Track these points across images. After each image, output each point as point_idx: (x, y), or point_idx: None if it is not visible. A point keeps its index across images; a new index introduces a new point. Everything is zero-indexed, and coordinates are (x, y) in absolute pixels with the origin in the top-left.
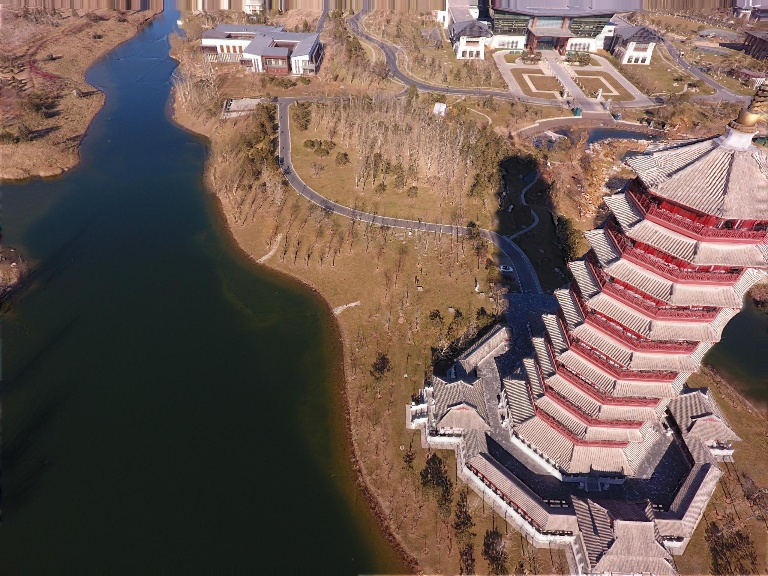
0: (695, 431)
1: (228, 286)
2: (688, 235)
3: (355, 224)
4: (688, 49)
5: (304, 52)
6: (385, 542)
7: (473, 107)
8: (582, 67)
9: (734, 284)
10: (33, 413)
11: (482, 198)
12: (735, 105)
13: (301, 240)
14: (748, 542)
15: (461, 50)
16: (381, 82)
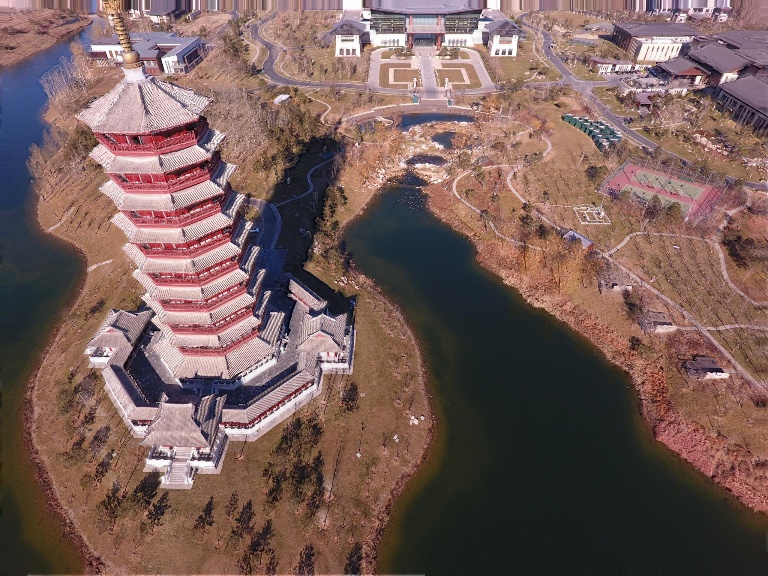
0: (306, 346)
1: (10, 251)
2: None
3: None
4: (558, 41)
5: (173, 53)
6: (21, 439)
7: (320, 98)
8: (451, 60)
9: (187, 195)
10: None
11: (267, 173)
12: (563, 88)
13: (88, 212)
14: (318, 432)
15: (338, 48)
16: (245, 79)
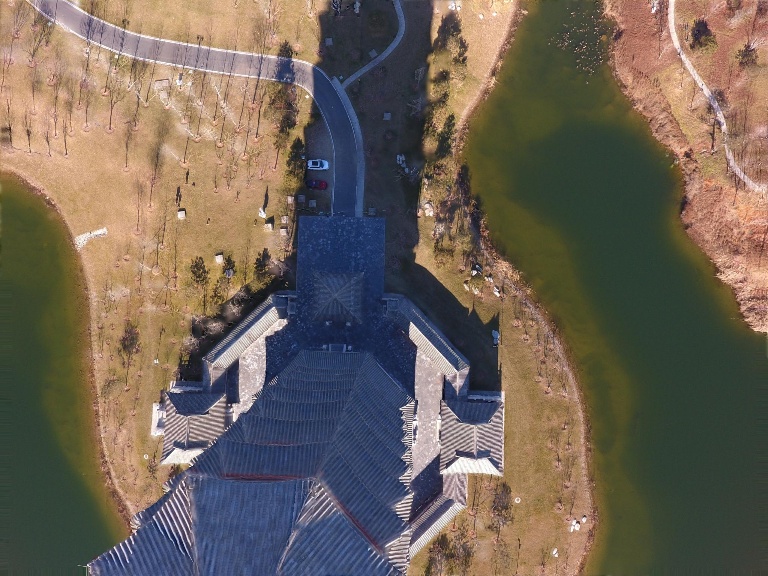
0: (454, 467)
1: None
2: None
3: (91, 58)
4: None
5: None
6: None
7: None
8: None
9: None
10: None
11: None
12: None
13: (10, 98)
14: (470, 552)
15: None
16: None
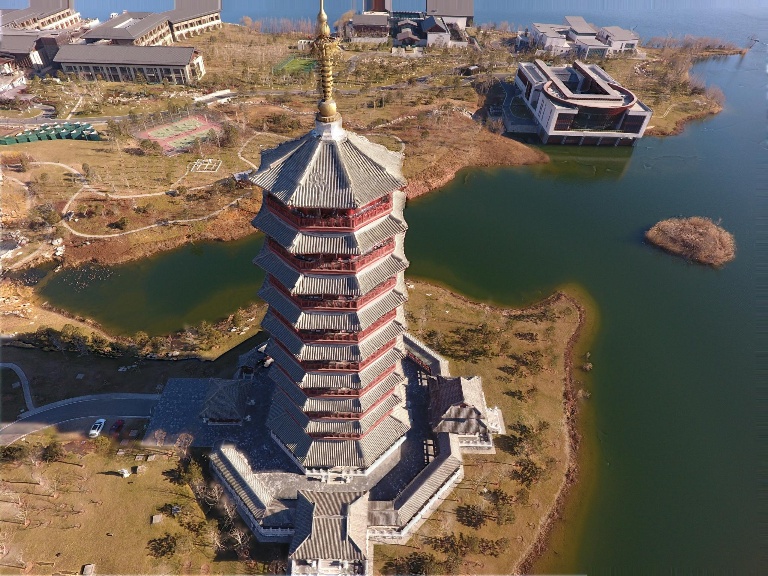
0: None
1: None
2: (381, 216)
3: None
4: None
5: None
6: None
7: None
8: None
9: None
10: None
11: None
12: None
13: None
14: (434, 333)
15: None
16: None
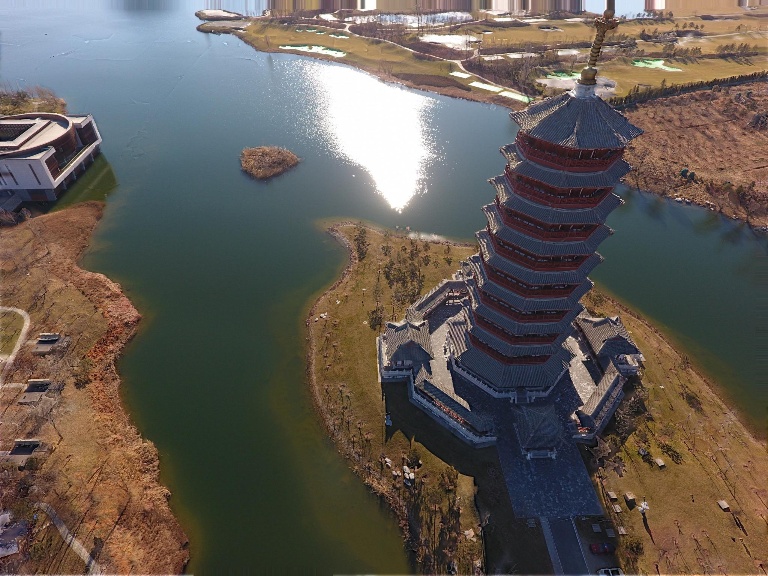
0: None
1: None
2: None
3: None
4: None
5: None
6: None
7: None
8: None
9: None
10: None
11: None
12: None
13: None
14: None
15: None
16: None
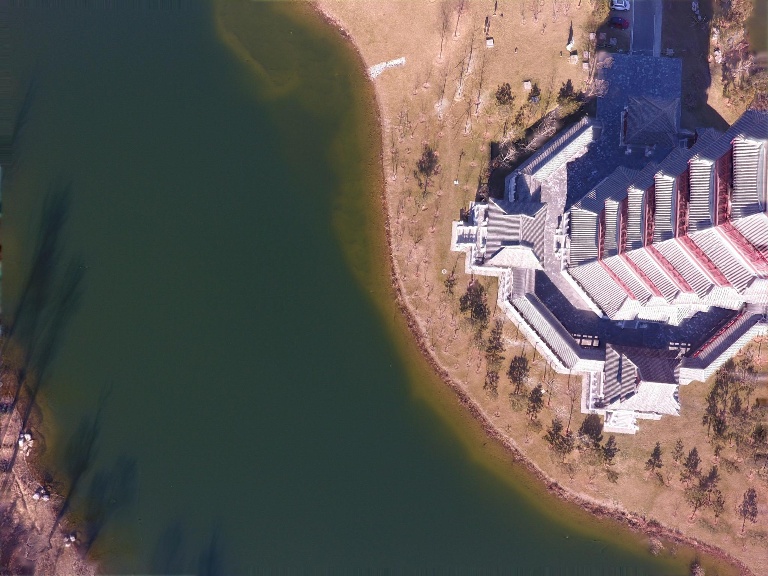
0: None
1: (223, 18)
2: None
3: None
4: None
5: None
6: (420, 356)
7: None
8: None
9: None
10: (49, 211)
11: None
12: None
13: None
14: (755, 376)
15: None
16: None
